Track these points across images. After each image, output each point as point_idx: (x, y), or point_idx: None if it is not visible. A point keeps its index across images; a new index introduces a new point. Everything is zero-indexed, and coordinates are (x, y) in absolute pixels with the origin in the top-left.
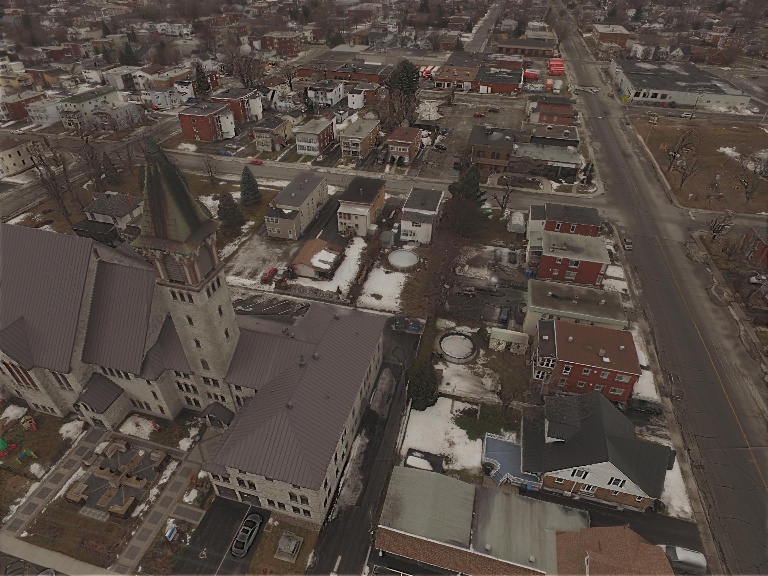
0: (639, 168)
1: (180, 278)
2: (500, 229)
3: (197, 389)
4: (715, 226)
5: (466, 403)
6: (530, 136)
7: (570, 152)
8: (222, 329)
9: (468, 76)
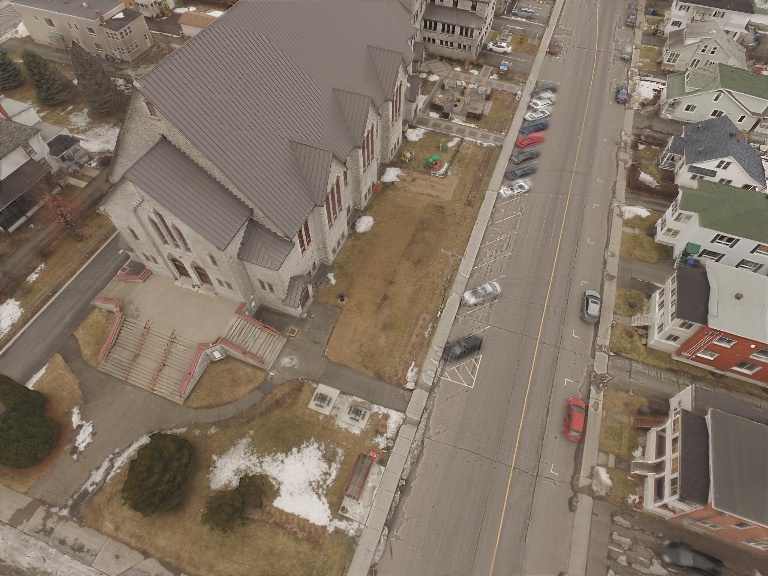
0: None
1: None
2: None
3: None
4: None
5: None
6: None
7: None
8: None
9: None
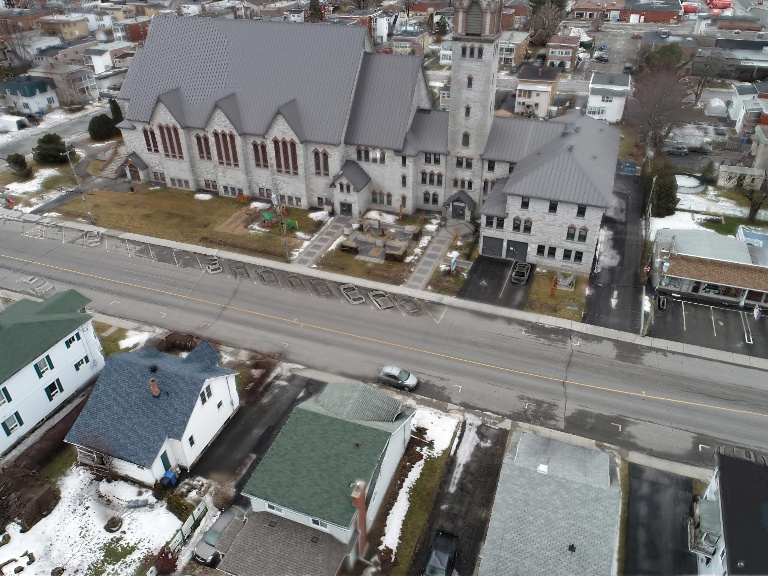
0: None
1: (477, 30)
2: (697, 114)
3: (443, 178)
4: None
5: (707, 215)
6: (715, 39)
7: (767, 52)
8: (490, 99)
9: (614, 6)
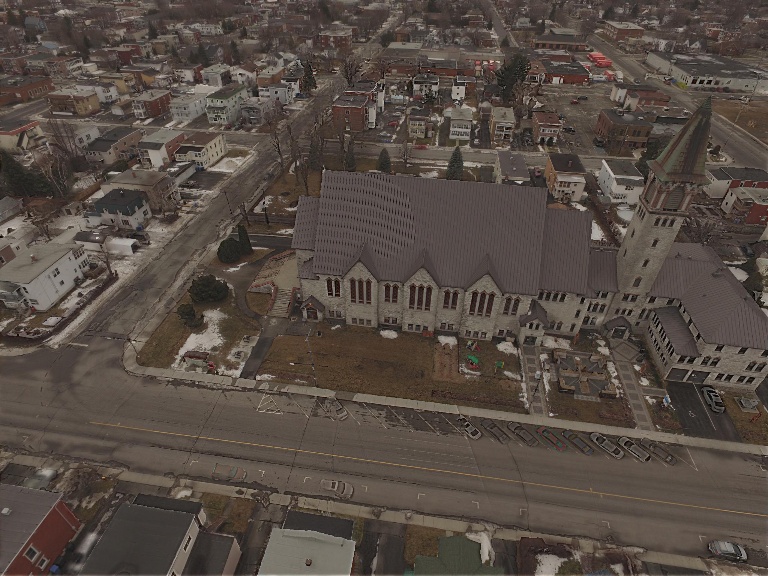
0: (744, 141)
1: (674, 206)
2: None
3: (605, 307)
4: None
5: None
6: (656, 116)
7: None
8: None
9: None
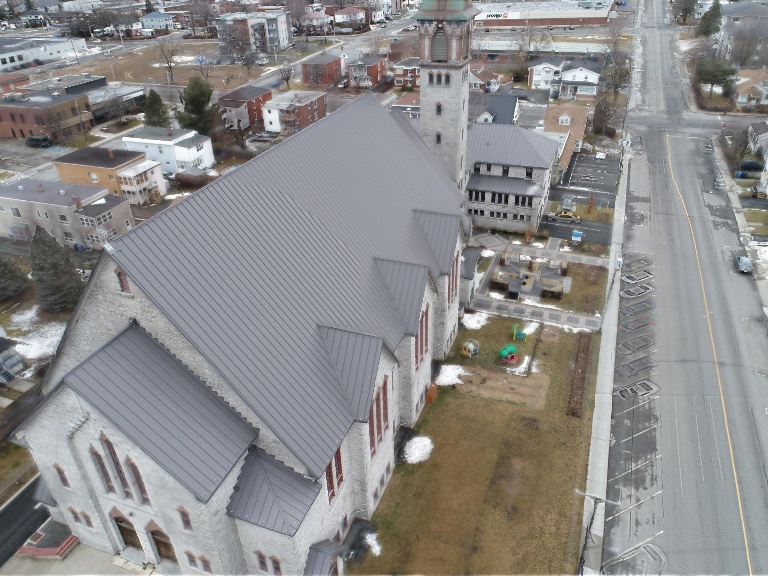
0: None
1: None
2: None
3: None
4: (285, 75)
5: None
6: (64, 89)
7: (118, 86)
8: None
9: None
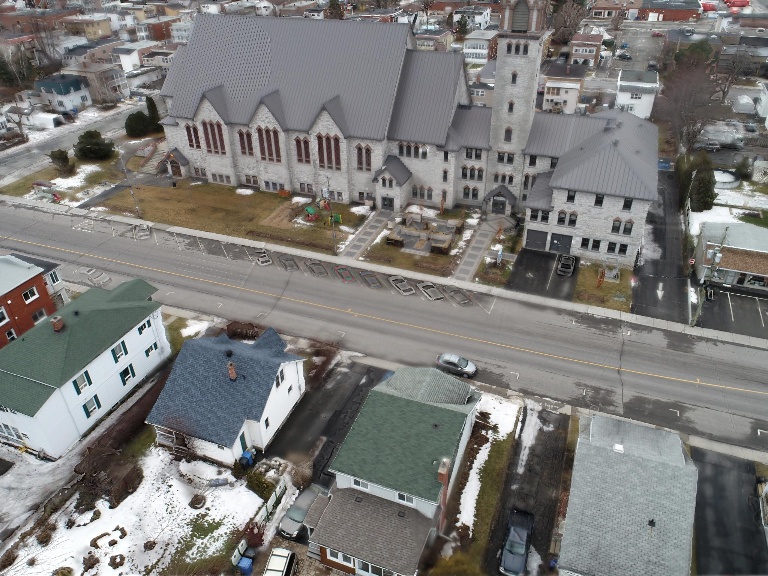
0: None
1: (523, 27)
2: (725, 111)
3: (483, 173)
4: None
5: (744, 209)
6: (739, 36)
7: None
8: (533, 95)
9: (632, 4)
